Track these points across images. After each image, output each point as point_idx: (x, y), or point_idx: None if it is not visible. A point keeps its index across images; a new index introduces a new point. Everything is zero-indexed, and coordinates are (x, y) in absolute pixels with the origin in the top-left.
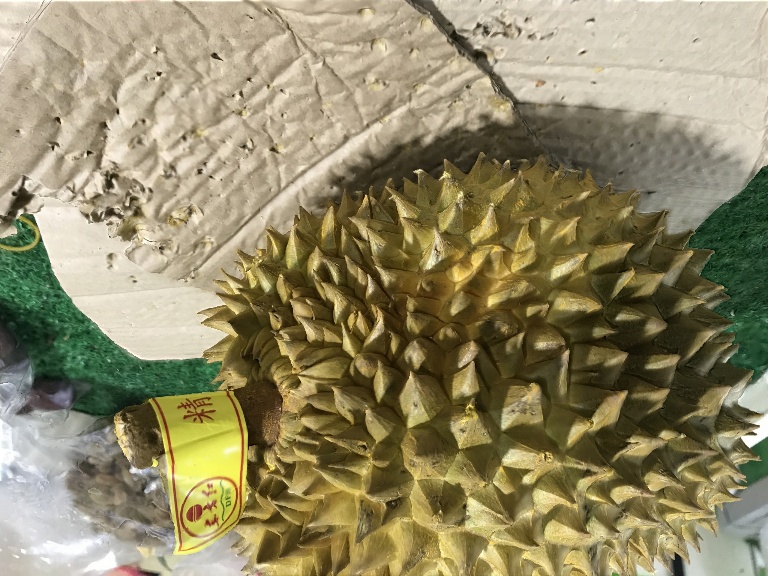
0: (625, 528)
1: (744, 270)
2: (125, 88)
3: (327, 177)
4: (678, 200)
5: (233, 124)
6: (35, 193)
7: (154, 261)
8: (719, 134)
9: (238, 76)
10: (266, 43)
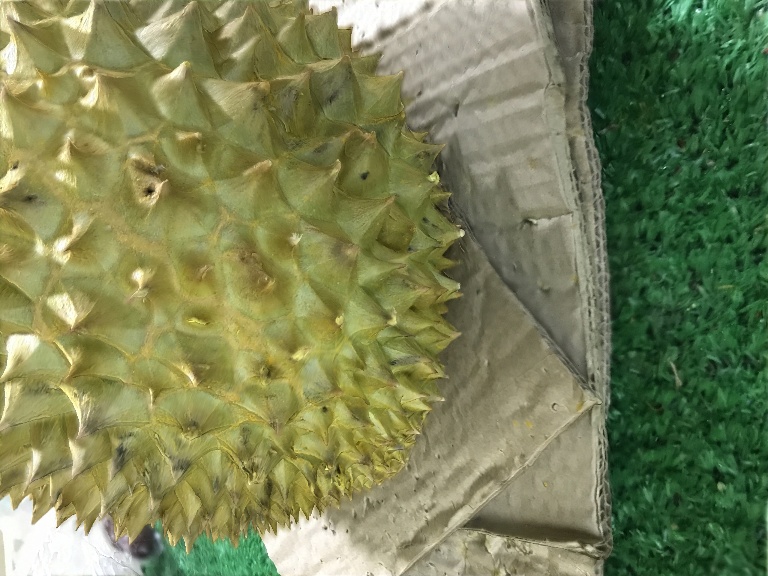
0: None
1: None
2: None
3: None
4: (489, 112)
5: None
6: None
7: None
8: None
9: None
10: None
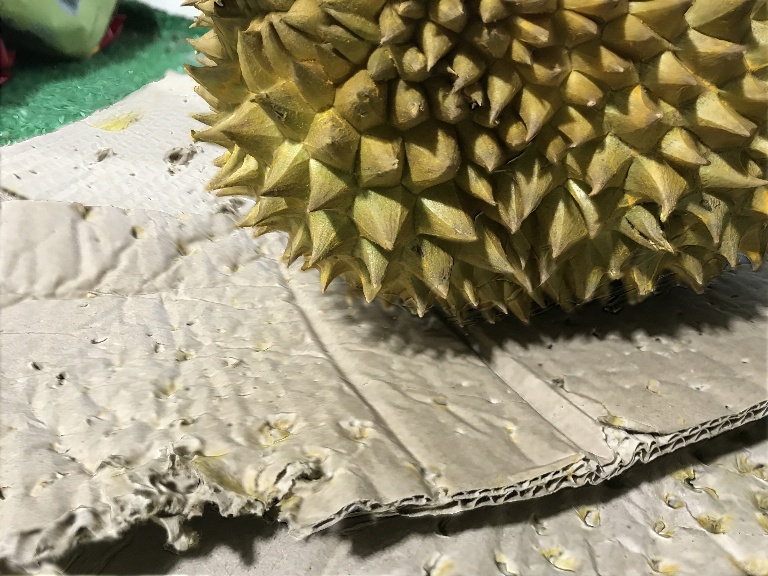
0: None
1: None
2: (40, 410)
3: (336, 324)
4: None
5: (192, 365)
6: (26, 562)
7: (337, 489)
8: None
9: (135, 337)
10: (124, 313)
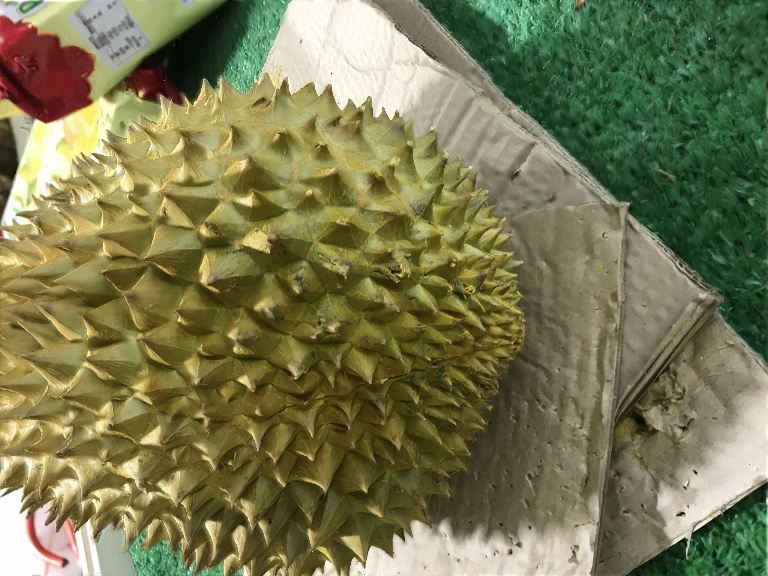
0: None
1: (763, 77)
2: None
3: None
4: (453, 141)
5: None
6: None
7: None
8: None
9: None
10: None
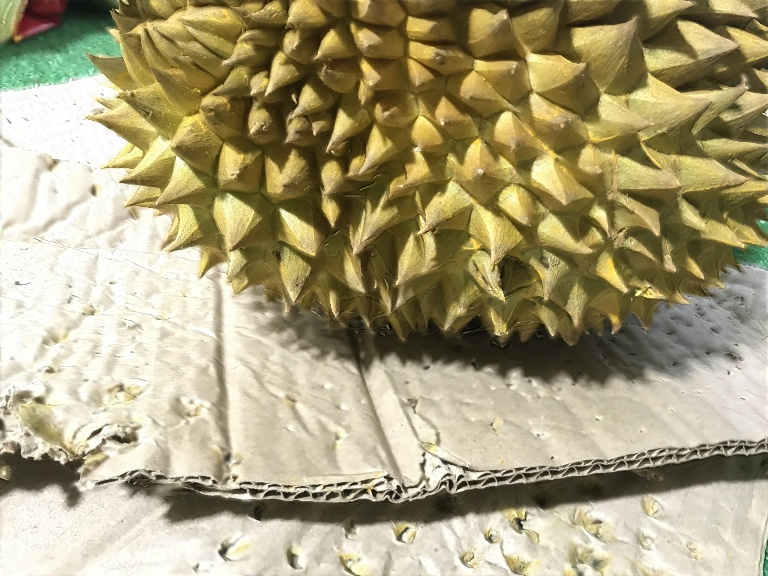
0: None
1: None
2: None
3: (243, 308)
4: None
5: (94, 320)
6: None
7: (135, 455)
8: None
9: (56, 286)
10: (58, 262)
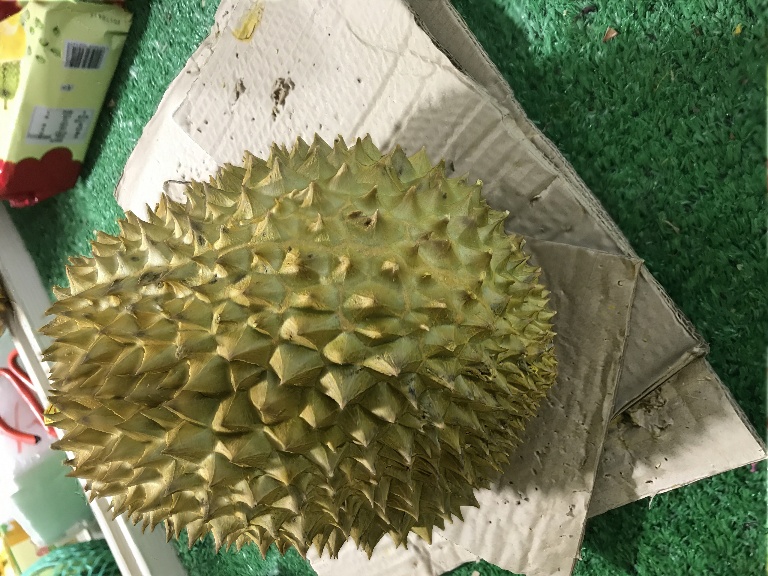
0: (148, 263)
1: (767, 163)
2: None
3: None
4: (475, 154)
5: None
6: None
7: None
8: (424, 96)
9: None
10: None
